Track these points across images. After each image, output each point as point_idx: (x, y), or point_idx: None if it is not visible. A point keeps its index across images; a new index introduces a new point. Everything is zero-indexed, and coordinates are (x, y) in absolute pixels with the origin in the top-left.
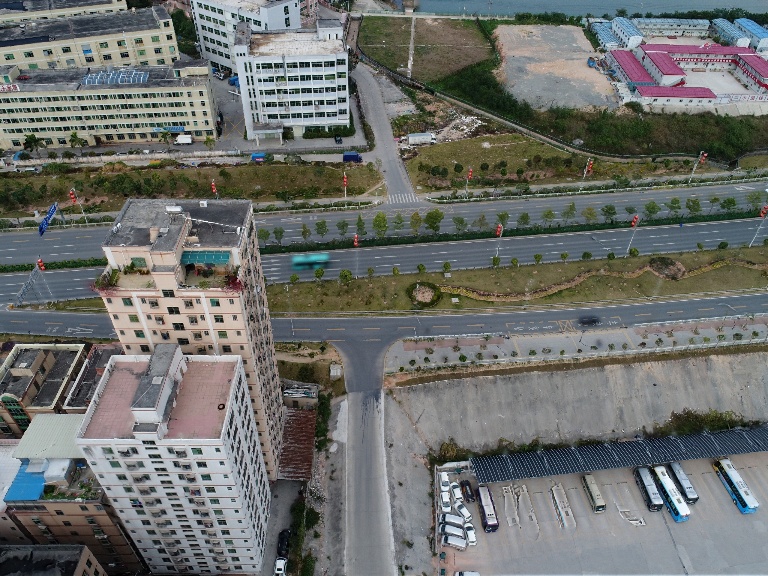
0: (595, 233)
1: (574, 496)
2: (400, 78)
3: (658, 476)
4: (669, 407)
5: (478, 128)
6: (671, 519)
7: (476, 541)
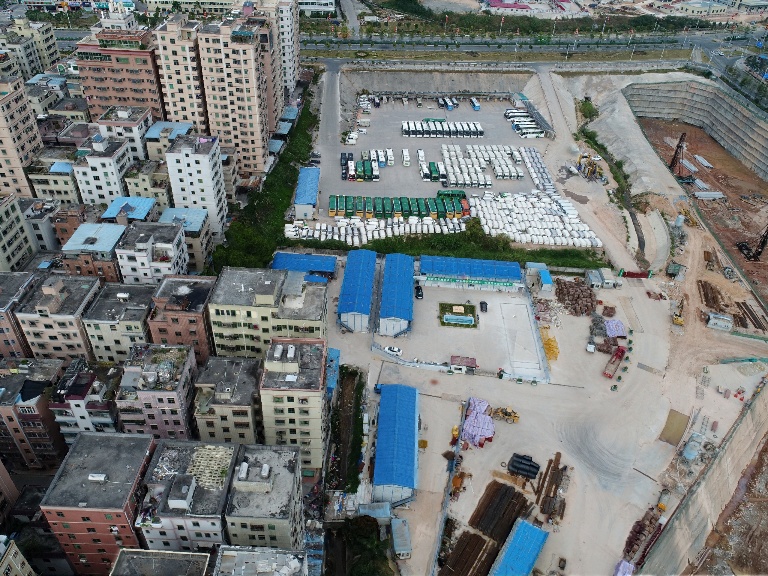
0: None
1: None
2: None
3: None
4: (458, 89)
5: (402, 18)
6: None
7: None
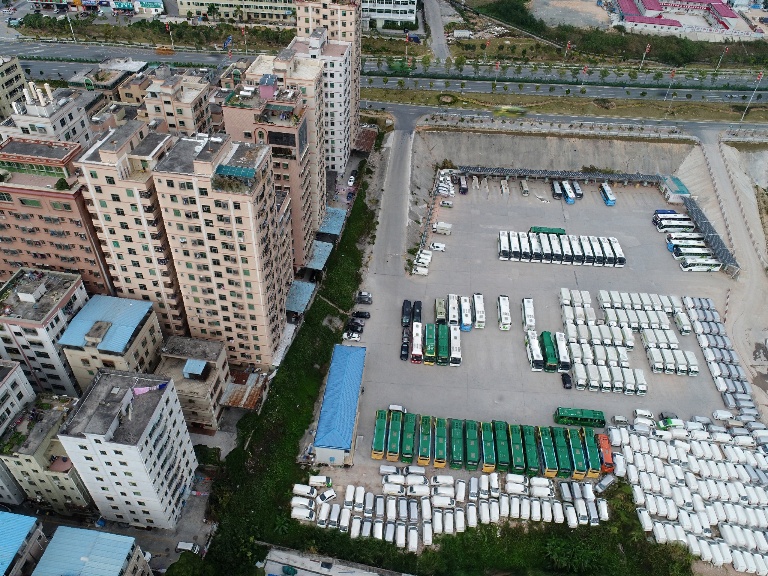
0: (564, 86)
1: (514, 190)
2: (456, 5)
3: (563, 184)
4: (582, 163)
5: (504, 33)
6: (565, 203)
7: (454, 195)
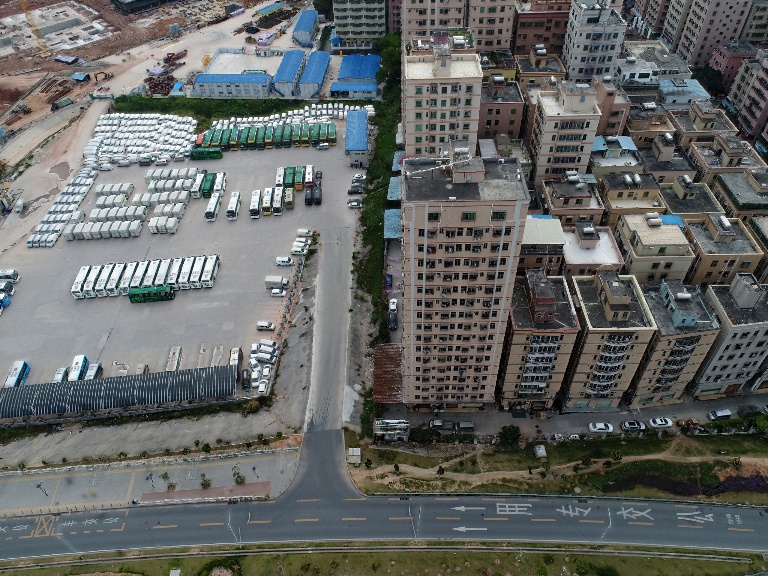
0: None
1: None
2: None
3: None
4: (4, 448)
5: None
6: None
7: None
